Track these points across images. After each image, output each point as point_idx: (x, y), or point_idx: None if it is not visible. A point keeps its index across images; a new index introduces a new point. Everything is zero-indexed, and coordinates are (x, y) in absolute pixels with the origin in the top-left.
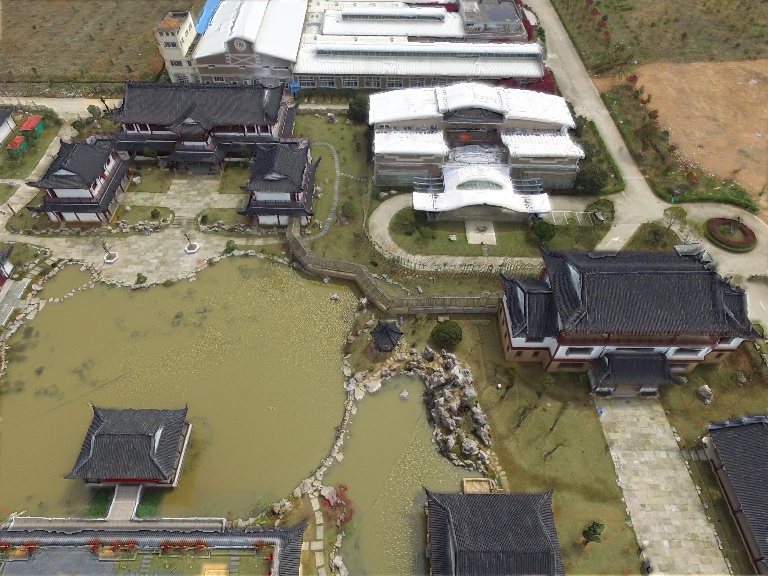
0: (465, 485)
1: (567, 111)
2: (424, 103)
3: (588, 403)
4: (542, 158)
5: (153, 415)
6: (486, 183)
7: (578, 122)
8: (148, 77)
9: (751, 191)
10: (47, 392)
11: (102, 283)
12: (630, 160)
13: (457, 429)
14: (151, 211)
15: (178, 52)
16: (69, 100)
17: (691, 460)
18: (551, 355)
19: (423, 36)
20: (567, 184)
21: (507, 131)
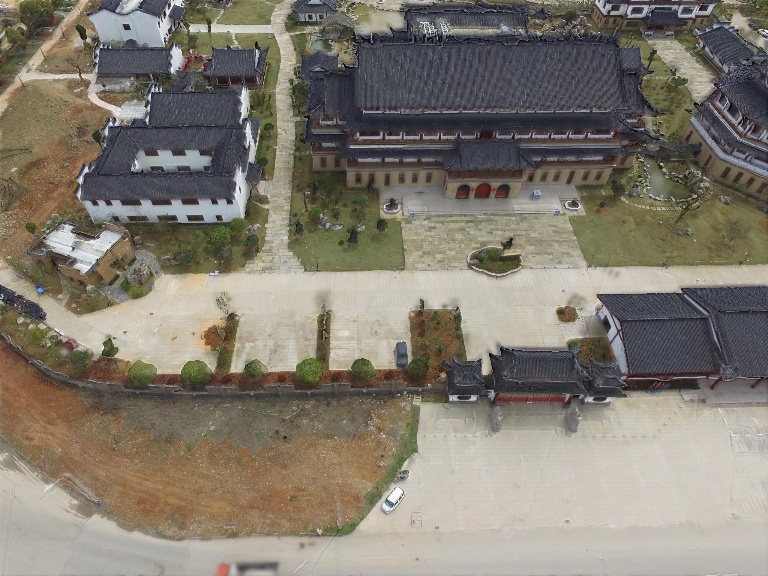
0: None
1: None
2: None
3: (641, 39)
4: None
5: None
6: None
7: None
8: None
9: None
10: None
11: (382, 10)
12: None
13: None
14: None
15: None
16: None
17: (691, 52)
18: None
19: None
20: None
21: None
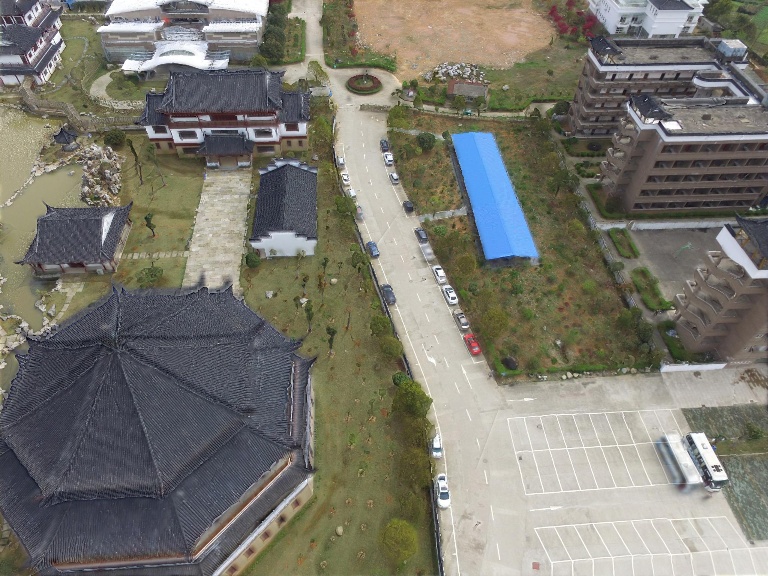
0: None
1: (267, 6)
2: None
3: (201, 174)
4: (229, 34)
5: None
6: (181, 51)
7: (276, 15)
8: None
9: (399, 60)
10: None
11: None
12: (320, 44)
13: (95, 185)
14: None
15: None
16: None
17: (254, 198)
18: None
19: None
20: None
21: (215, 20)
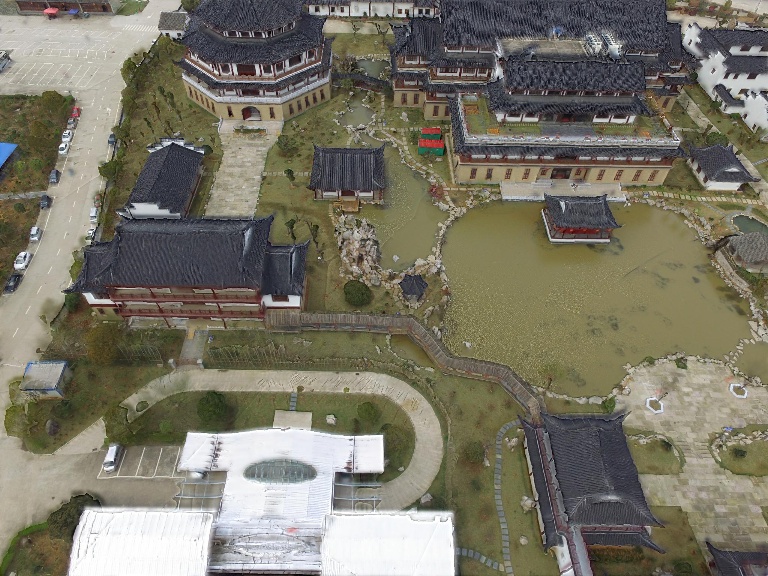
0: None
1: None
2: None
3: None
4: None
5: (576, 223)
6: (269, 477)
7: None
8: None
9: None
10: (674, 265)
11: None
12: None
13: None
14: None
15: None
16: None
17: None
18: None
19: None
20: None
21: None
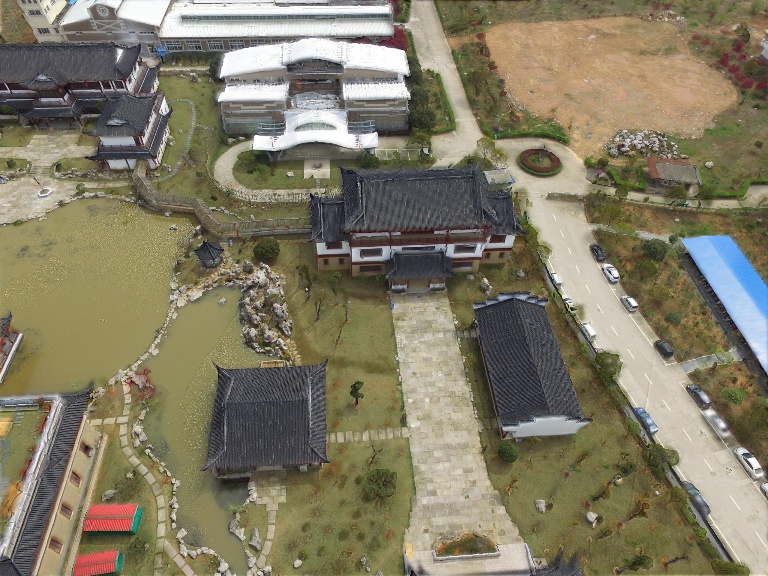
0: (261, 366)
1: (406, 62)
2: (271, 57)
3: (384, 299)
4: (374, 101)
5: None
6: (321, 125)
7: (416, 72)
8: None
9: (567, 127)
10: None
11: None
12: (466, 105)
13: (261, 323)
14: (7, 161)
15: (43, 19)
16: None
17: (463, 337)
18: (350, 259)
19: (290, 2)
20: (402, 126)
21: (349, 81)
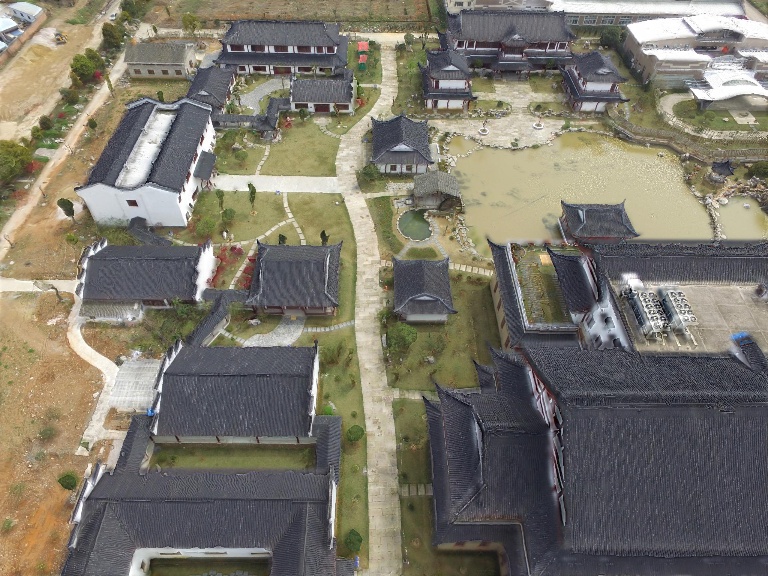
0: None
1: None
2: (679, 28)
3: None
4: None
5: (603, 206)
6: (745, 81)
7: None
8: (423, 18)
9: None
10: (498, 205)
11: (487, 147)
12: None
13: None
14: (498, 102)
15: None
16: (371, 34)
17: None
18: None
19: None
20: None
21: (742, 49)
